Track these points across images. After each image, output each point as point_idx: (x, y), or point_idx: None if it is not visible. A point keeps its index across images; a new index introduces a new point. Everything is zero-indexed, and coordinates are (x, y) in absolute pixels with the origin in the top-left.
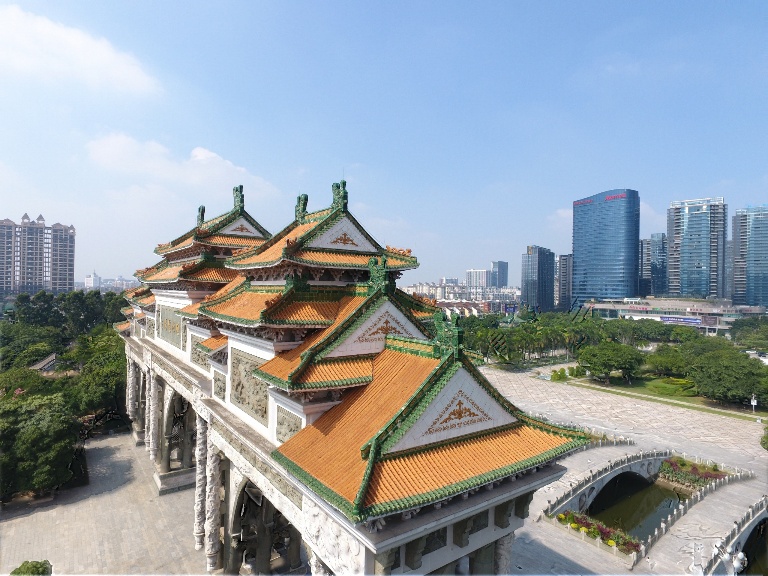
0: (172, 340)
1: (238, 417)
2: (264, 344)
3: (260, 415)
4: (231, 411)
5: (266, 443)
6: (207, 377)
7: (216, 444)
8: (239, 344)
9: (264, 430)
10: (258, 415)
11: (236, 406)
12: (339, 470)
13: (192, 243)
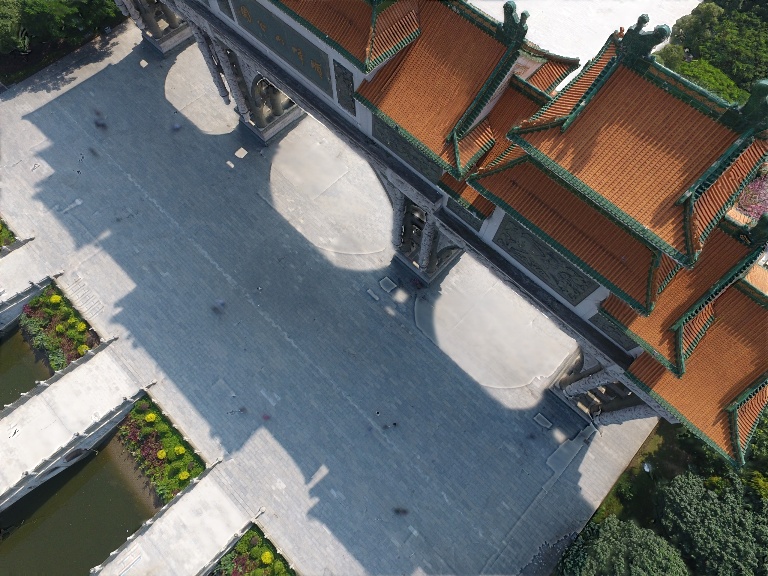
0: None
1: None
2: None
3: None
4: None
5: None
6: None
7: None
8: None
9: None
10: None
11: None
12: None
13: None
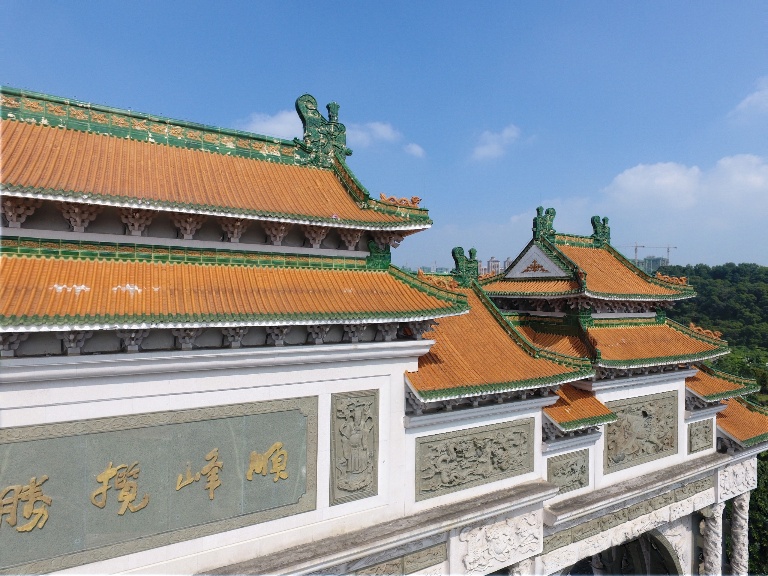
0: (184, 525)
1: (626, 480)
2: (686, 374)
3: (665, 449)
4: (609, 484)
5: (686, 464)
6: (524, 483)
7: (565, 564)
8: (626, 392)
9: (673, 459)
10: (662, 452)
11: (620, 470)
12: (762, 422)
13: (403, 226)
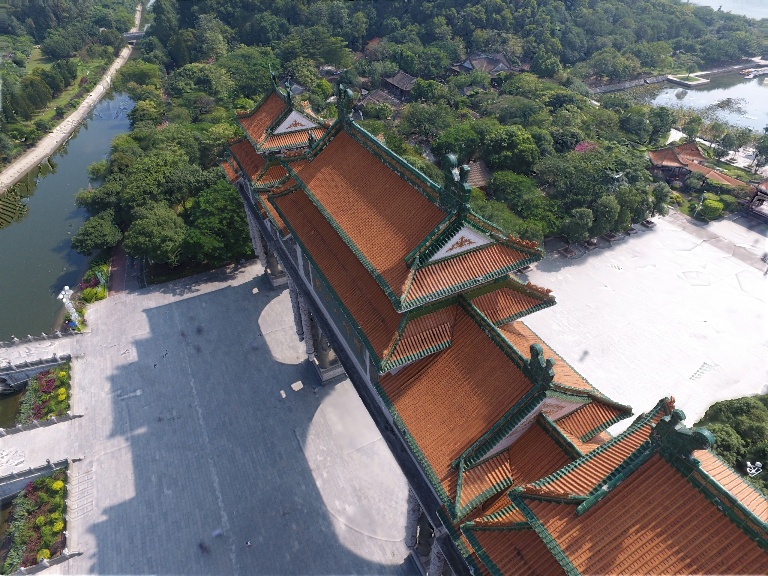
0: None
1: None
2: None
3: None
4: None
5: None
6: None
7: None
8: None
9: None
10: None
11: None
12: None
13: None
